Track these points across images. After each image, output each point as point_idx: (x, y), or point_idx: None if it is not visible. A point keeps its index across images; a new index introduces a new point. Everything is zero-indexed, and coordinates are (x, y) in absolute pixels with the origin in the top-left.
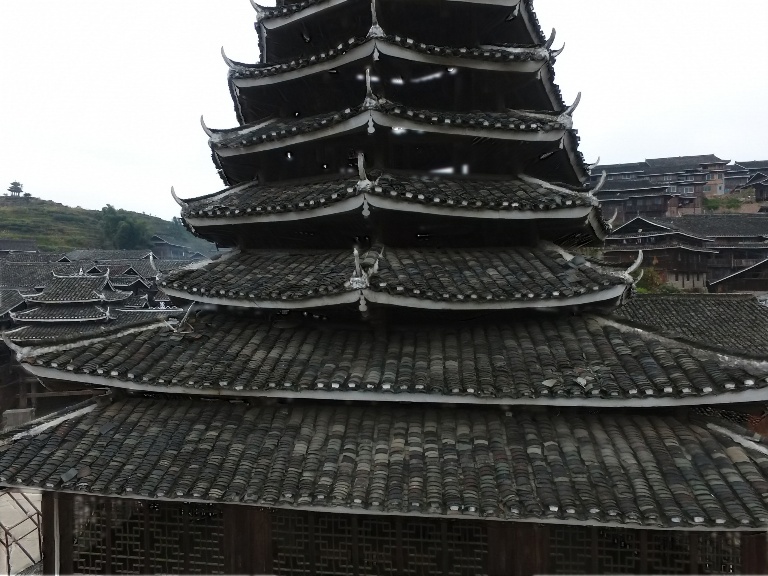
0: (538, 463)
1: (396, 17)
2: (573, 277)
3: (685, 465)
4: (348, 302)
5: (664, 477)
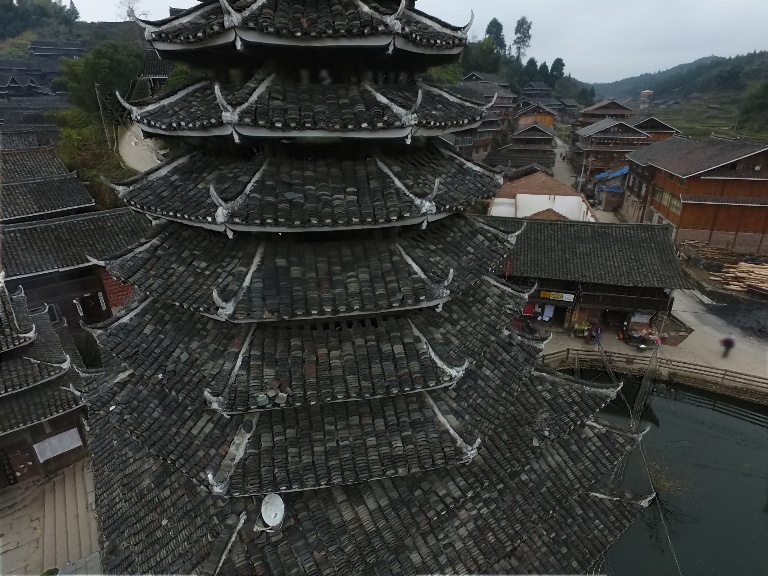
0: (530, 485)
1: (400, 143)
2: (520, 356)
3: (576, 449)
4: (458, 463)
5: (573, 462)
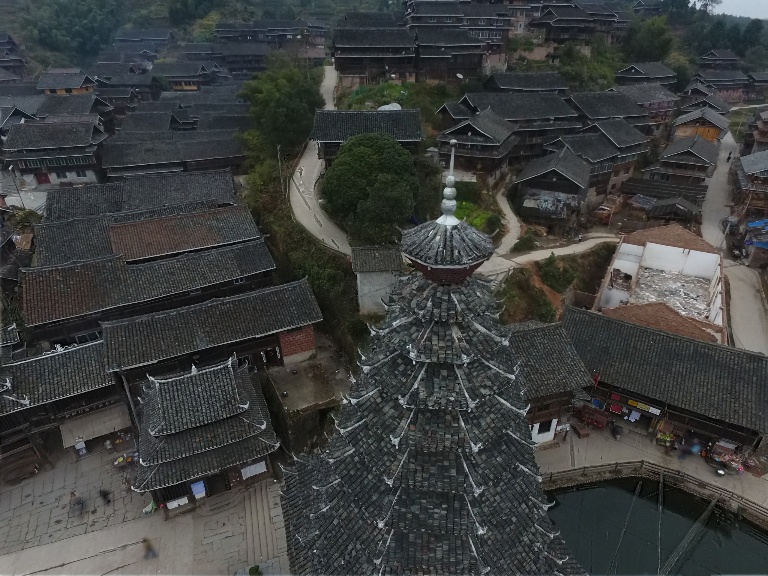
0: None
1: None
2: (543, 568)
3: None
4: None
5: None
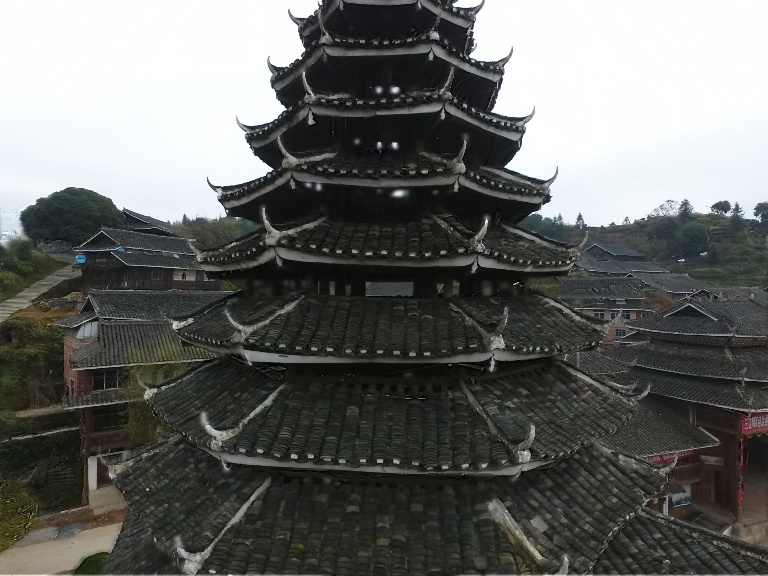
0: None
1: None
2: None
3: None
4: None
5: None
